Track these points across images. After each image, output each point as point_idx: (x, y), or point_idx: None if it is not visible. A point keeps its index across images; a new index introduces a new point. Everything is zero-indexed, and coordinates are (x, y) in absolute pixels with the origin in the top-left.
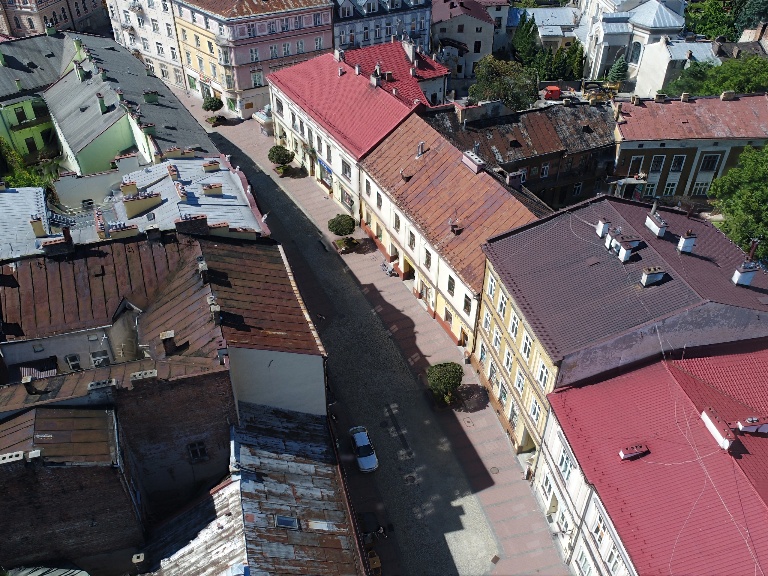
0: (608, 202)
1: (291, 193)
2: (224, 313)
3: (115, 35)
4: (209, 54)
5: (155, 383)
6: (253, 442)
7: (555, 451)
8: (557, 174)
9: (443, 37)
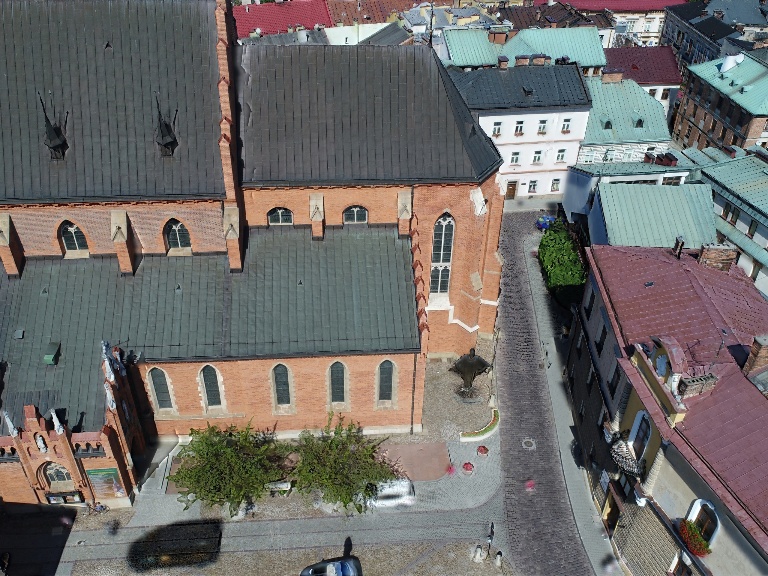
0: None
1: None
2: None
3: None
4: None
5: None
6: None
7: None
8: None
9: None
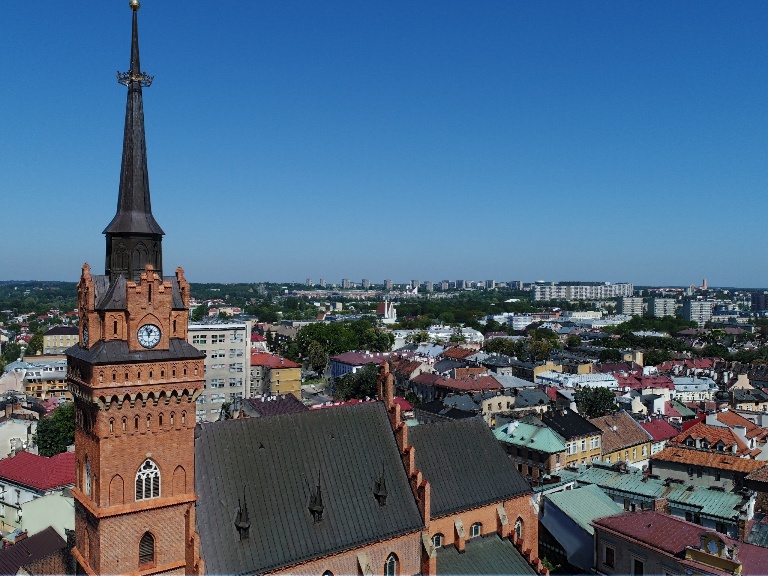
0: None
1: None
2: None
3: None
4: None
5: None
6: None
7: None
8: None
9: None
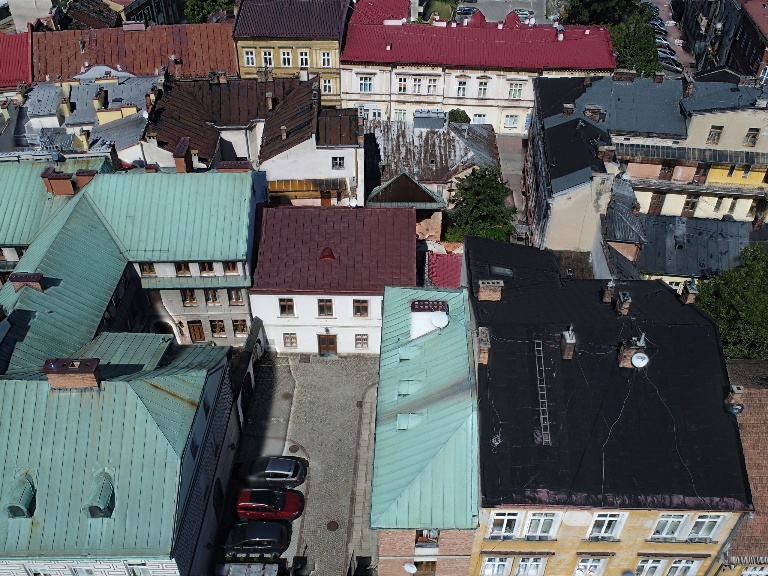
0: None
1: None
2: None
3: None
4: None
5: None
6: None
7: (356, 86)
8: None
9: None
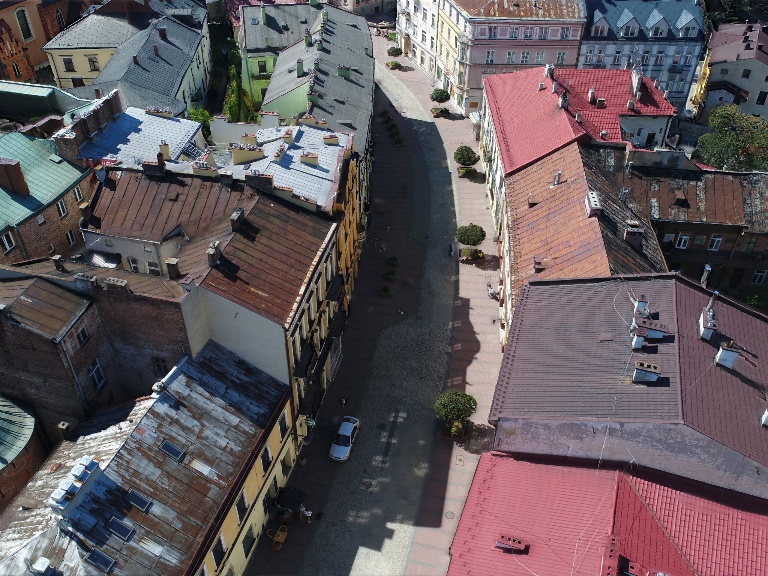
0: (674, 283)
1: (458, 194)
2: (225, 259)
3: (397, 18)
4: (454, 48)
5: (123, 292)
6: (196, 376)
7: None
8: (731, 251)
9: (722, 79)
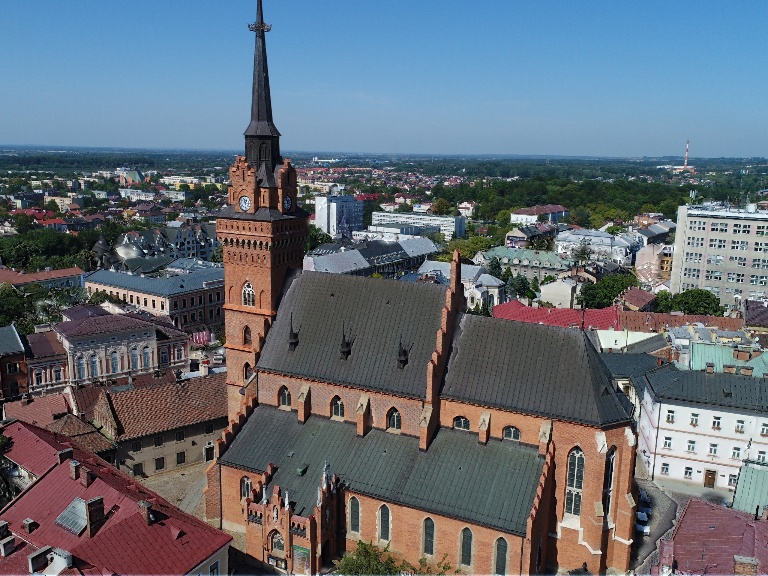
0: None
1: None
2: None
3: None
4: None
5: None
6: None
7: None
8: None
9: None
